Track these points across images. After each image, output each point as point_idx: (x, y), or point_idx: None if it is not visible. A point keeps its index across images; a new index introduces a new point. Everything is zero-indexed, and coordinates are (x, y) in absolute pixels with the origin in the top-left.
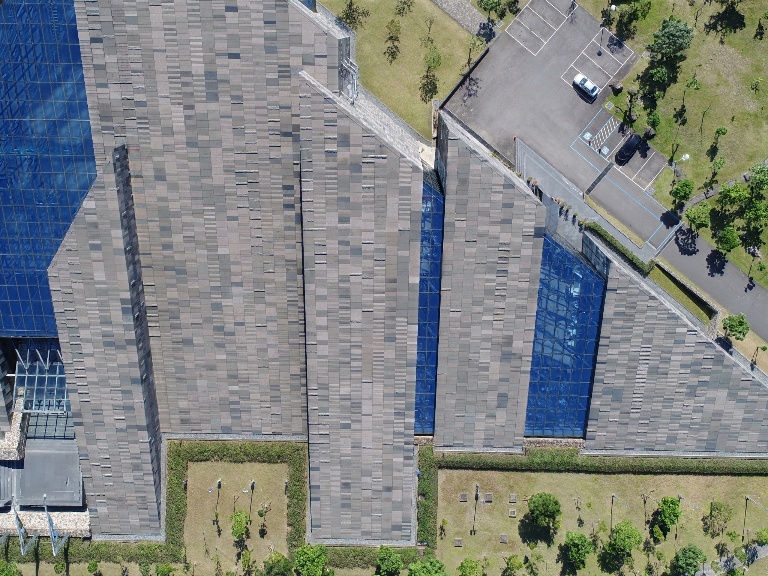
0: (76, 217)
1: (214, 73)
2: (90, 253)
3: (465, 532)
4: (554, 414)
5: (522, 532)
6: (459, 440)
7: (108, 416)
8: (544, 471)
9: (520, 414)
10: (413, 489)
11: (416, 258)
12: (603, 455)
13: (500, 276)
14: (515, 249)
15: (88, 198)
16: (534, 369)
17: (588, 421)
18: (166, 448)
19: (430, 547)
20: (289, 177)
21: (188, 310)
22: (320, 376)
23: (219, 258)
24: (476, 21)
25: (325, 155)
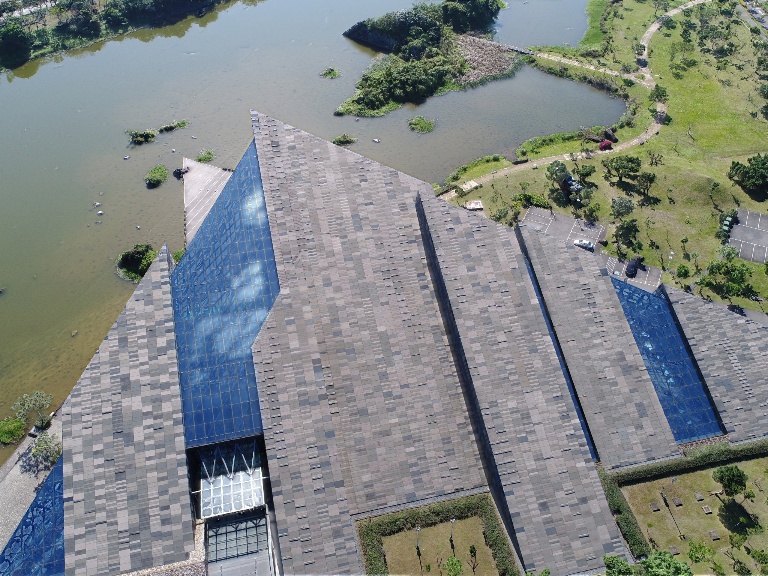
0: (275, 302)
1: (358, 215)
2: (286, 327)
3: (675, 539)
4: None
5: (726, 525)
6: (623, 459)
7: (306, 478)
8: (711, 467)
9: (662, 420)
10: None
11: (530, 286)
12: (750, 442)
13: (592, 308)
14: (594, 287)
15: (284, 287)
16: (652, 380)
17: (719, 414)
18: (356, 529)
19: None
20: (420, 268)
21: (360, 383)
22: (488, 395)
23: (379, 335)
24: None
25: (447, 231)
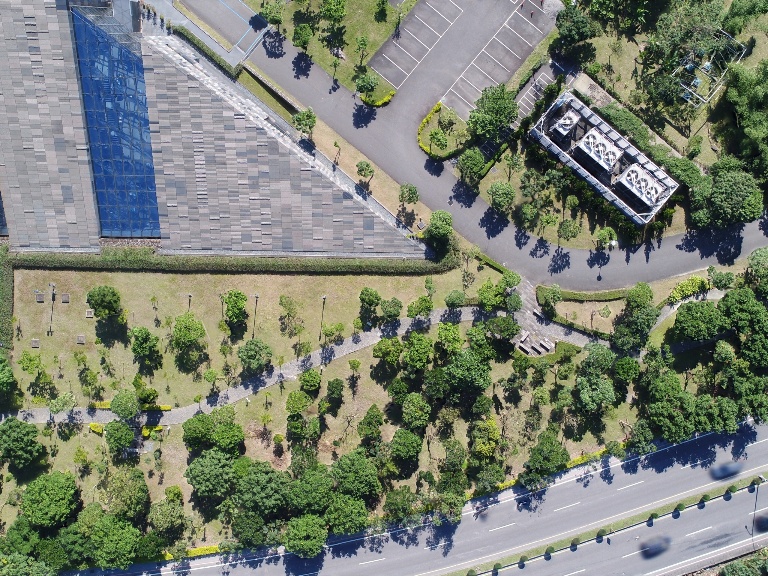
0: None
1: None
2: None
3: (42, 333)
4: (143, 219)
5: (99, 333)
6: (34, 239)
7: None
8: (121, 271)
9: (89, 210)
10: None
11: None
12: (180, 254)
13: (33, 54)
14: (41, 23)
15: None
16: (96, 161)
17: (159, 217)
18: None
19: (4, 347)
20: None
21: None
22: None
23: None
24: None
25: None
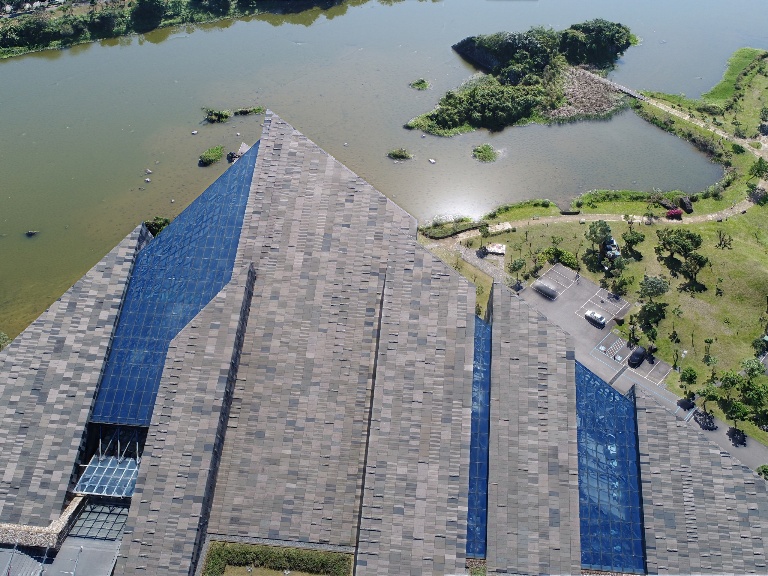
0: (208, 303)
1: (330, 235)
2: (209, 331)
3: None
4: None
5: None
6: (513, 565)
7: (170, 484)
8: None
9: (574, 536)
10: None
11: (470, 350)
12: None
13: (541, 390)
14: (552, 368)
15: (222, 291)
16: (582, 489)
17: (646, 550)
18: (207, 549)
19: None
20: (372, 303)
21: (268, 404)
22: (380, 453)
23: (305, 361)
24: None
25: (404, 272)
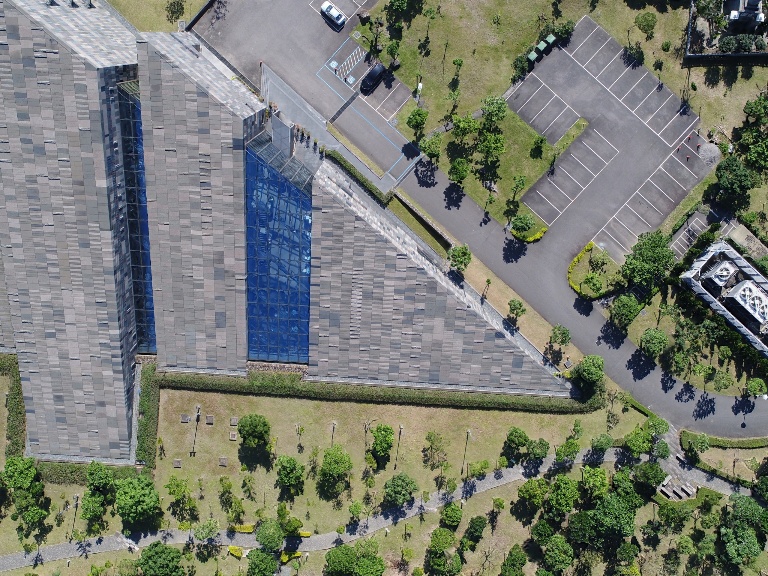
0: None
1: None
2: None
3: (185, 453)
4: (287, 341)
5: (242, 456)
6: (182, 360)
7: None
8: (266, 395)
9: (240, 335)
10: (135, 408)
11: (100, 160)
12: (326, 382)
13: (204, 189)
14: (216, 161)
15: None
16: (252, 289)
17: (309, 346)
18: None
19: (147, 466)
20: None
21: None
22: (19, 281)
23: None
24: None
25: None
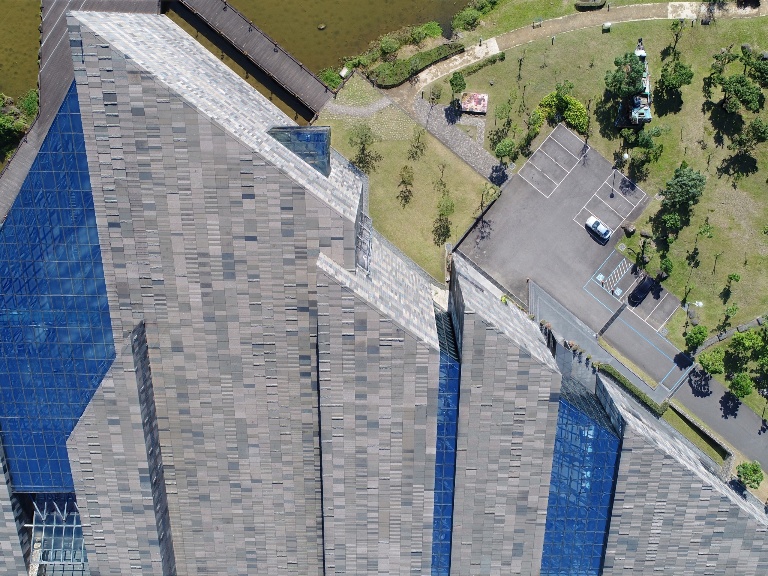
0: (95, 395)
1: (231, 254)
2: (108, 427)
3: None
4: None
5: None
6: None
7: (126, 574)
8: None
9: (535, 562)
10: None
11: (433, 431)
12: None
13: (516, 437)
14: (531, 413)
15: (107, 378)
16: (549, 520)
17: (603, 568)
18: None
19: None
20: (306, 348)
21: (205, 469)
22: (337, 537)
23: (236, 422)
24: (488, 164)
25: (342, 338)
